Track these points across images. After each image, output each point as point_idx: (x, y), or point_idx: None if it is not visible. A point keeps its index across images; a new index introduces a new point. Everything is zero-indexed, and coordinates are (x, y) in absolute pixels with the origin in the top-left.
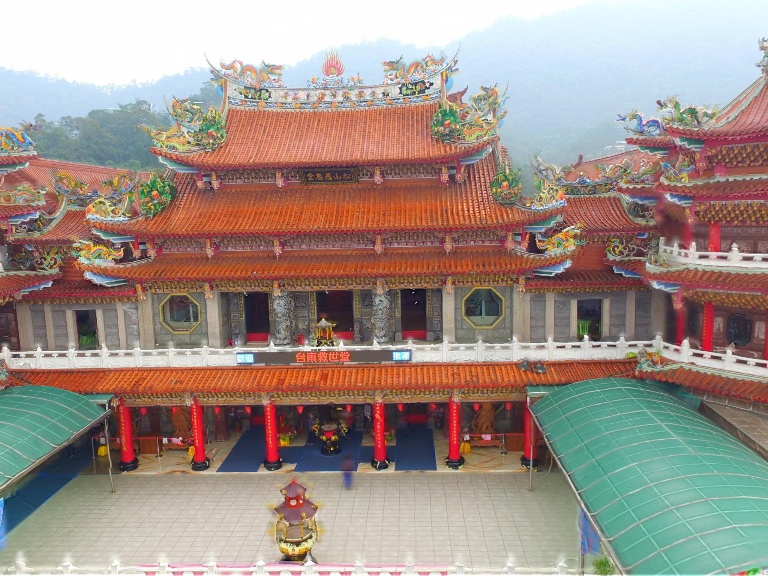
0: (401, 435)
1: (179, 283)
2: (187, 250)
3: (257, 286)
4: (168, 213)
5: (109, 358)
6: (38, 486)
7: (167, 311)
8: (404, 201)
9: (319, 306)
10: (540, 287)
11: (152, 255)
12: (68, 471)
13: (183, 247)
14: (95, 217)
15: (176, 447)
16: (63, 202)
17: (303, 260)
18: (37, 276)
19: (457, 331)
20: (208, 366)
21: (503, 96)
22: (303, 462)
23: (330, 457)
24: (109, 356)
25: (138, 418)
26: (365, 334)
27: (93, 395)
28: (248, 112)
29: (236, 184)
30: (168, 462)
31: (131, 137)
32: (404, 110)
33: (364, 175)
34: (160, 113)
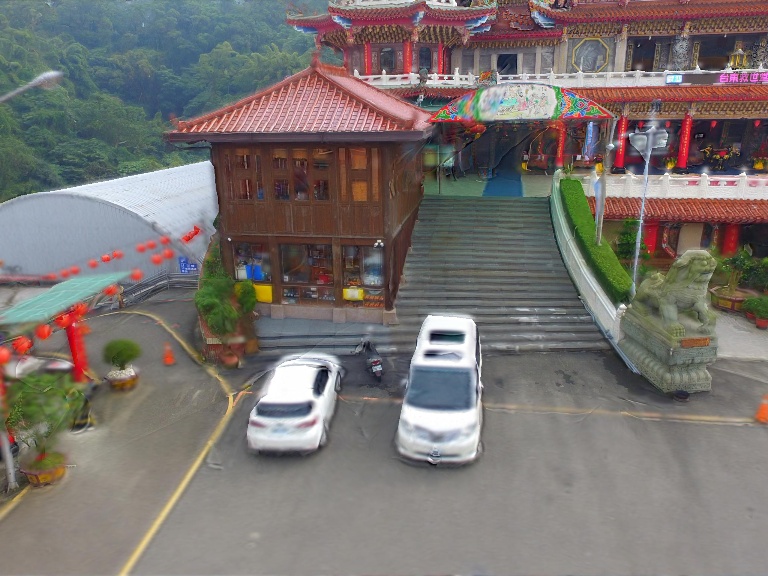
0: None
1: (598, 27)
2: (601, 1)
3: (665, 30)
4: None
5: (555, 80)
6: (509, 172)
7: None
8: None
9: (701, 57)
10: None
11: (576, 3)
12: (519, 169)
13: None
14: None
15: (583, 165)
16: None
17: (710, 5)
18: None
19: None
20: (640, 86)
21: None
22: None
23: None
24: (555, 79)
25: None
26: None
27: None
28: None
29: None
30: (585, 172)
31: None
32: None
33: None
34: None
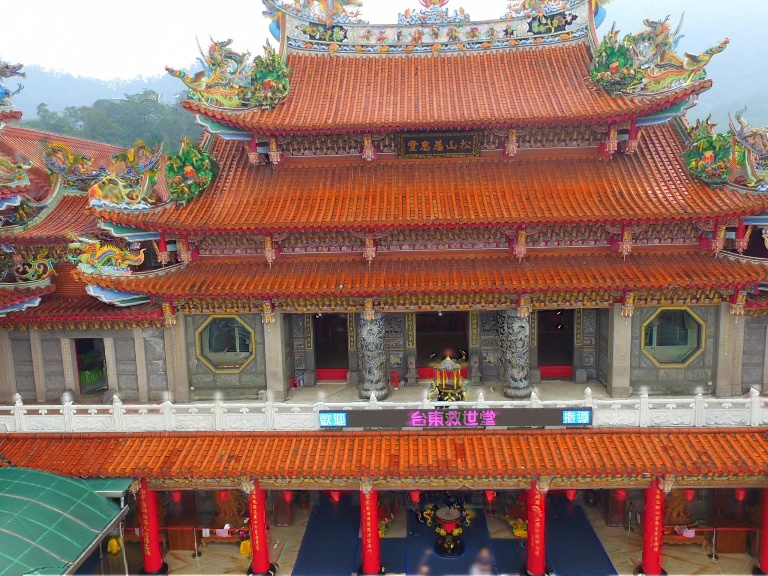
0: (546, 521)
1: (225, 300)
2: (235, 252)
3: (339, 305)
4: (208, 198)
5: (124, 417)
6: None
7: (206, 340)
8: (553, 180)
9: (419, 331)
10: (765, 308)
11: (185, 259)
12: None
13: (229, 248)
14: (102, 203)
15: (221, 540)
16: (57, 184)
17: (407, 267)
18: (17, 291)
19: (632, 371)
20: (275, 430)
21: (676, 34)
22: (414, 571)
23: (452, 561)
24: (124, 414)
25: (166, 502)
26: (484, 371)
27: (100, 480)
28: (315, 58)
29: (303, 157)
30: (211, 567)
31: (138, 128)
32: (535, 54)
33: (489, 143)
34: (168, 104)
